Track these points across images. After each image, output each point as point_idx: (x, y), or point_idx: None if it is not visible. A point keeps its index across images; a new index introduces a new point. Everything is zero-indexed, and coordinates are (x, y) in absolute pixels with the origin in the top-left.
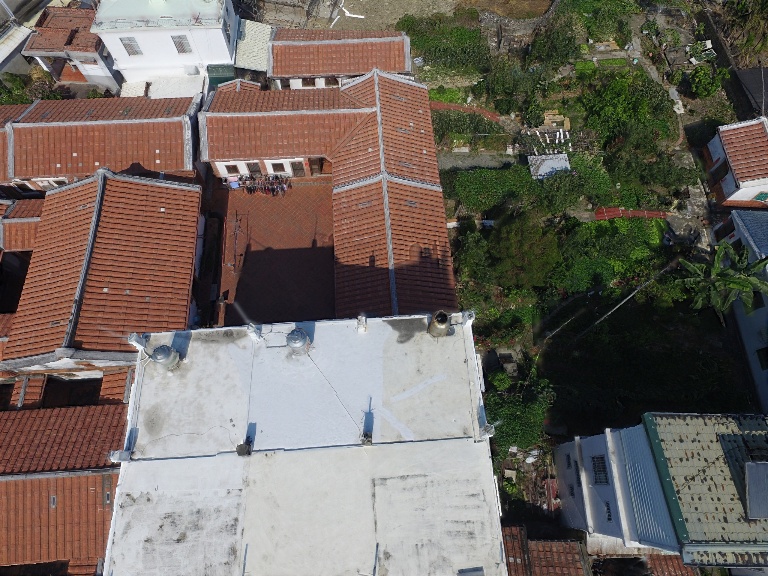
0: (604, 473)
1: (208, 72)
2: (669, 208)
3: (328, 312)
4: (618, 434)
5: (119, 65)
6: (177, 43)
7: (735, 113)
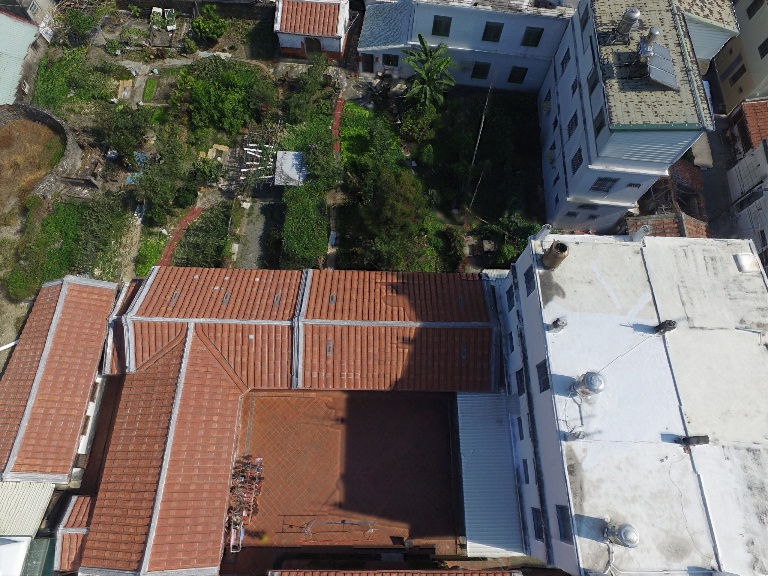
0: (608, 182)
1: None
2: (335, 95)
3: (423, 413)
4: (600, 158)
5: None
6: None
7: (243, 19)
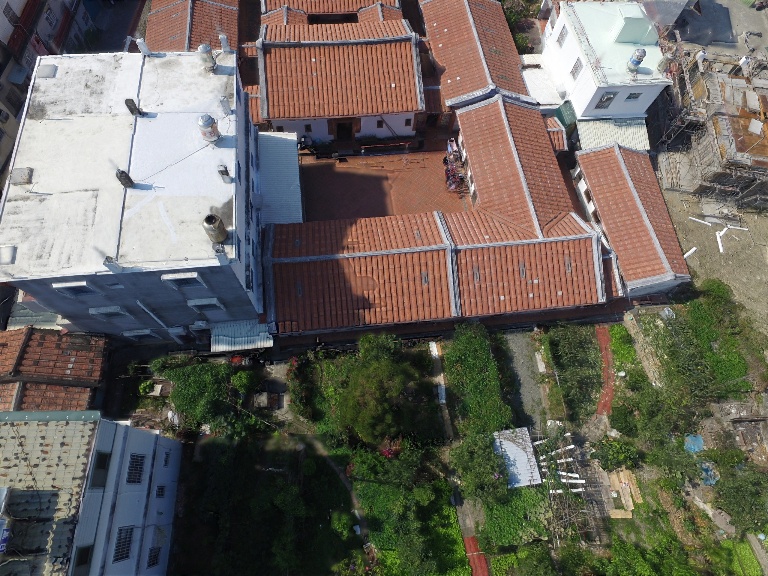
0: None
1: (564, 104)
2: None
3: None
4: None
5: (549, 40)
6: (576, 65)
7: None
